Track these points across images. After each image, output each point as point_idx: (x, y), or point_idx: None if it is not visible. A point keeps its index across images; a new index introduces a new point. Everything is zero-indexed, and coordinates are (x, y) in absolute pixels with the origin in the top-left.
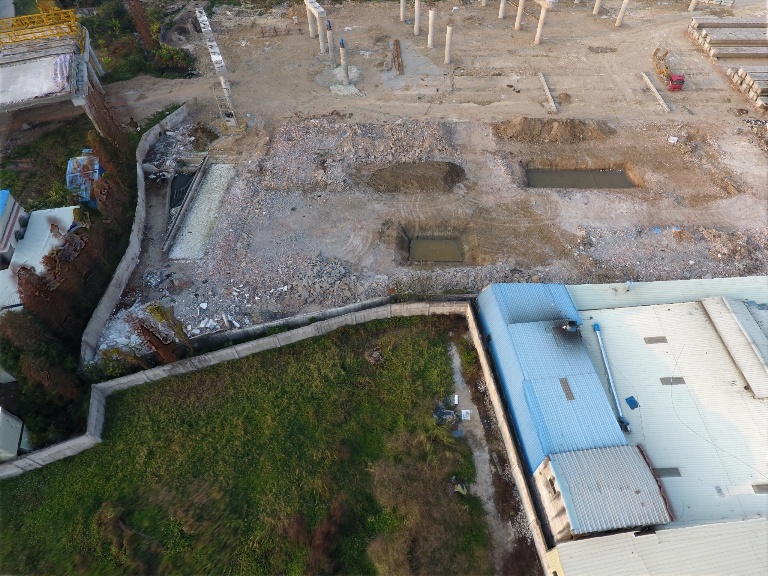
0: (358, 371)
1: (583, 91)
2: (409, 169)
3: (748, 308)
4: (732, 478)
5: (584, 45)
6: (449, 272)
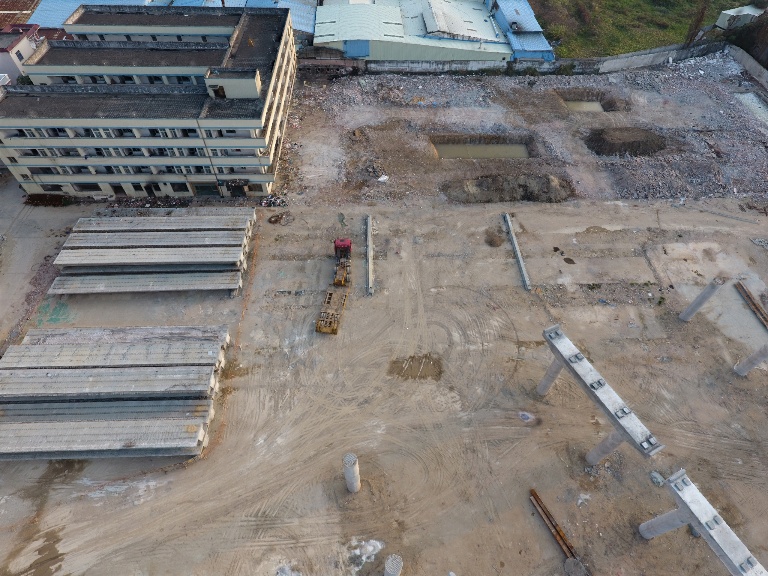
0: (601, 55)
1: (469, 250)
2: (636, 135)
3: (425, 33)
4: (457, 5)
5: (449, 384)
6: (573, 81)
